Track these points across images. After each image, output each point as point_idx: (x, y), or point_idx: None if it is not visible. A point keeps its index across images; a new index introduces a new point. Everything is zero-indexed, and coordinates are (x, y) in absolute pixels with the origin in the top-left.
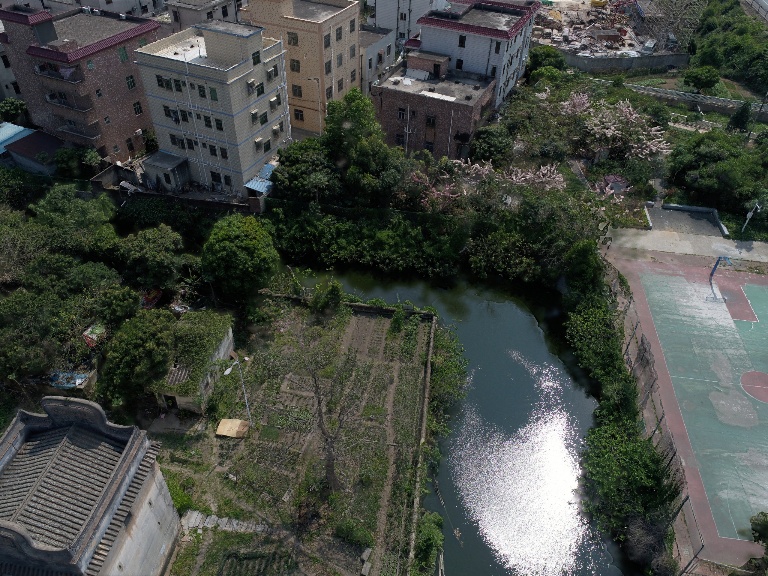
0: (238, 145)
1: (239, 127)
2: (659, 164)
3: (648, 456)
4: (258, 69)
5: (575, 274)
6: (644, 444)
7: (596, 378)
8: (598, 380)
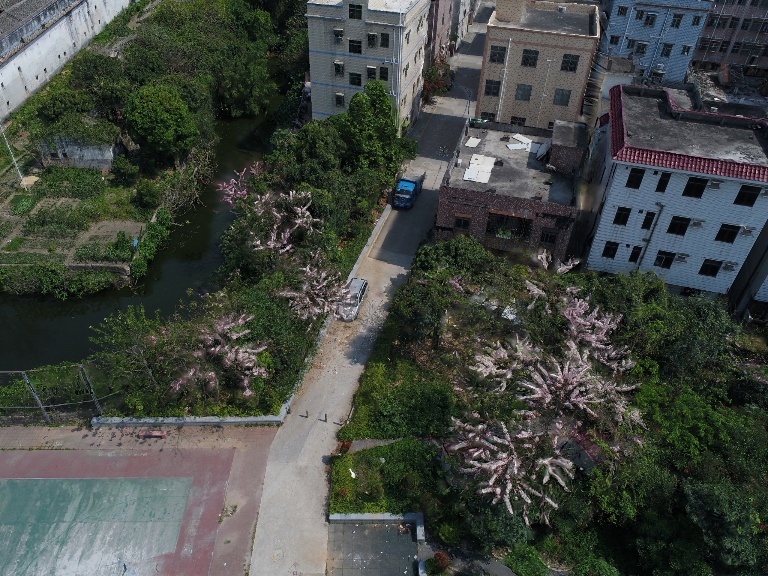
0: (312, 82)
1: (316, 66)
2: (490, 508)
3: None
4: (356, 24)
5: None
6: None
7: None
8: None
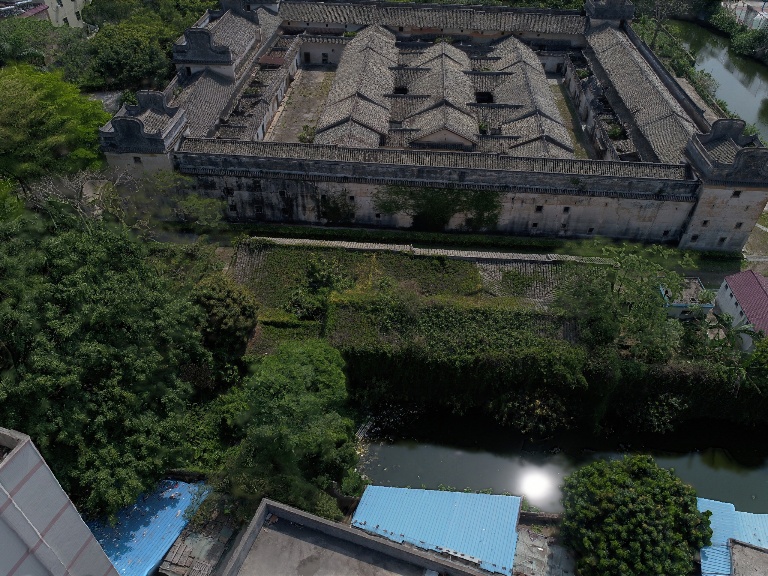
0: None
1: None
2: None
3: (758, 30)
4: None
5: (711, 3)
6: (756, 29)
7: (727, 32)
8: (729, 32)
